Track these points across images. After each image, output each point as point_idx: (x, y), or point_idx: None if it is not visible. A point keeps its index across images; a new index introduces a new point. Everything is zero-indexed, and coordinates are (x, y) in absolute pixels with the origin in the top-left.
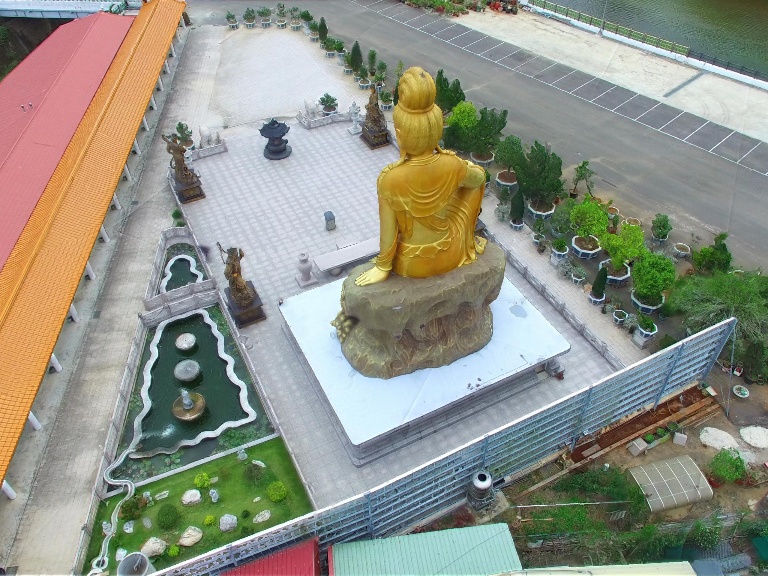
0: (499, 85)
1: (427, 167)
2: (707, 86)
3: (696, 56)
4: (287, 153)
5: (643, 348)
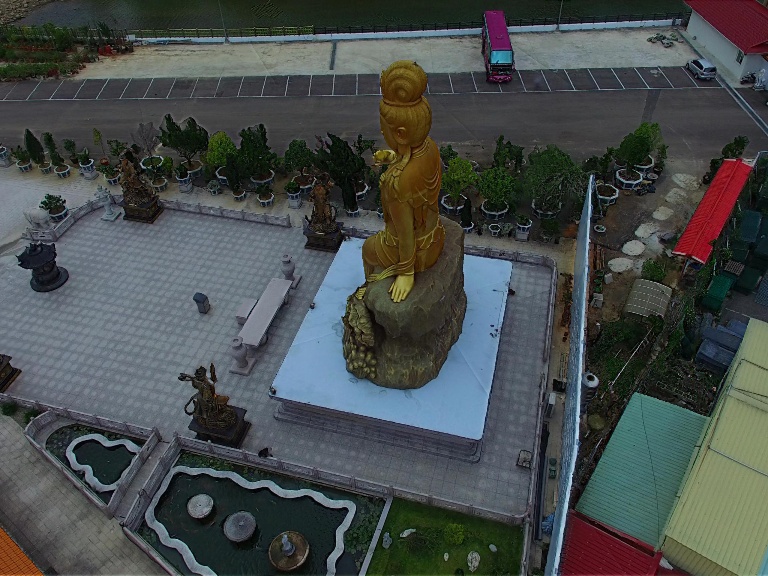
0: (195, 115)
1: (429, 153)
2: (349, 51)
3: (321, 31)
4: (64, 274)
5: (528, 240)
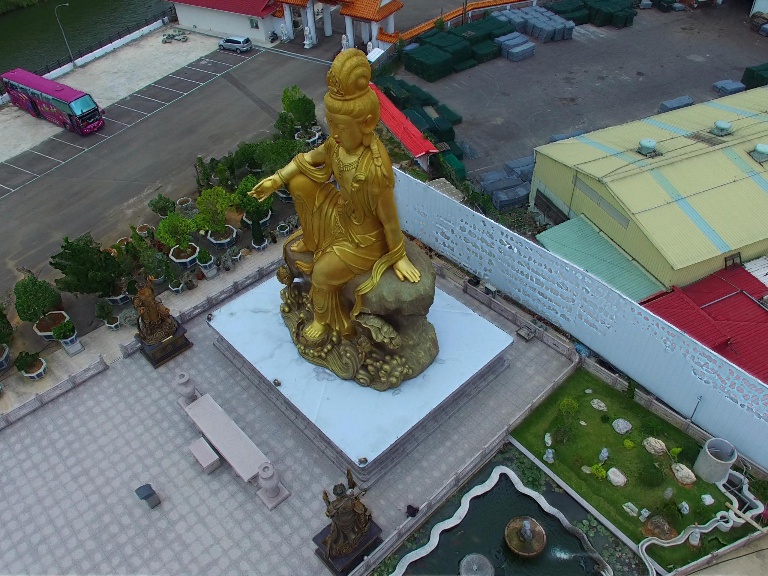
0: None
1: None
2: None
3: None
4: None
5: None
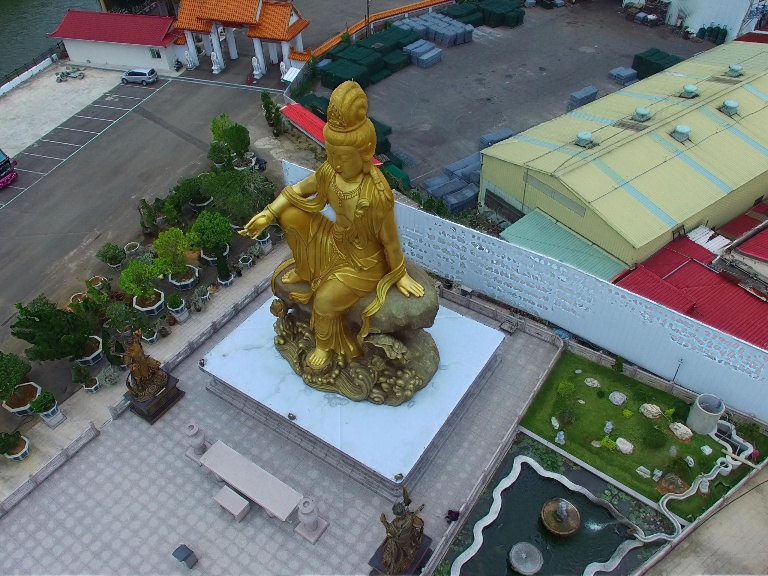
0: None
1: None
2: None
3: None
4: None
5: (273, 248)
